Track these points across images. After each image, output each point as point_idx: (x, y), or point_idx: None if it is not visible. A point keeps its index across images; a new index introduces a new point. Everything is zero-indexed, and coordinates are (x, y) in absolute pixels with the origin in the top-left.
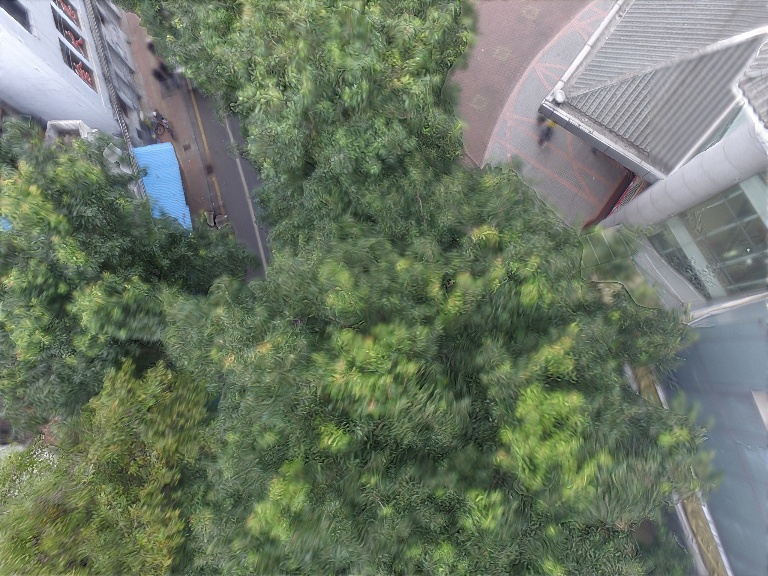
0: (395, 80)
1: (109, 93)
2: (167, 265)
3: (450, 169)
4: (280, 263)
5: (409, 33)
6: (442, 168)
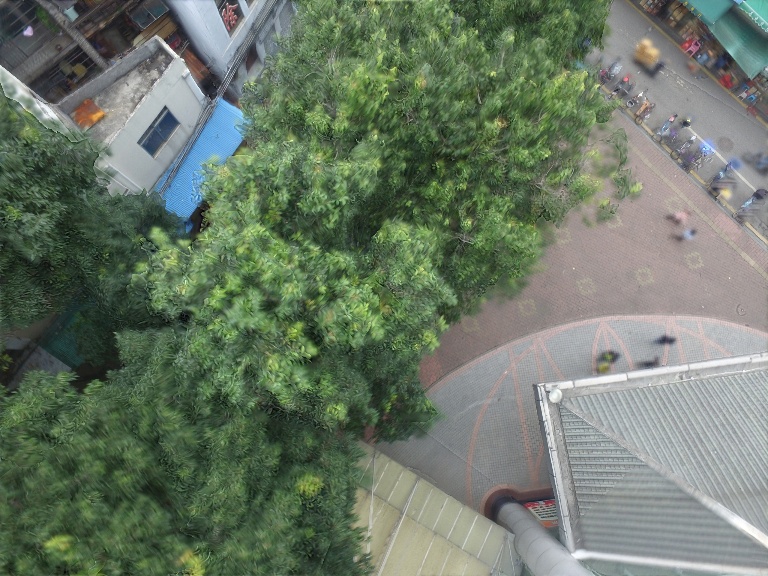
0: (270, 361)
1: (243, 42)
2: (58, 266)
3: (304, 436)
4: (1, 434)
5: (336, 325)
6: (288, 435)
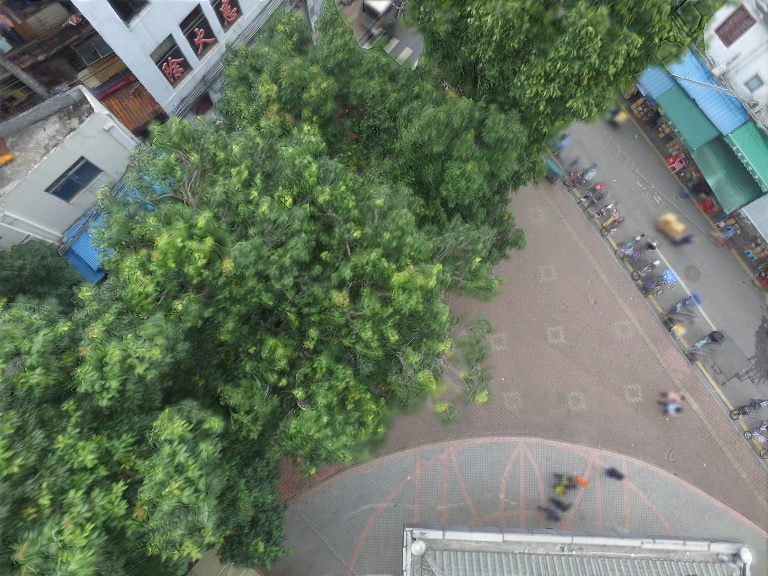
0: None
1: (190, 94)
2: None
3: None
4: None
5: (36, 555)
6: None
